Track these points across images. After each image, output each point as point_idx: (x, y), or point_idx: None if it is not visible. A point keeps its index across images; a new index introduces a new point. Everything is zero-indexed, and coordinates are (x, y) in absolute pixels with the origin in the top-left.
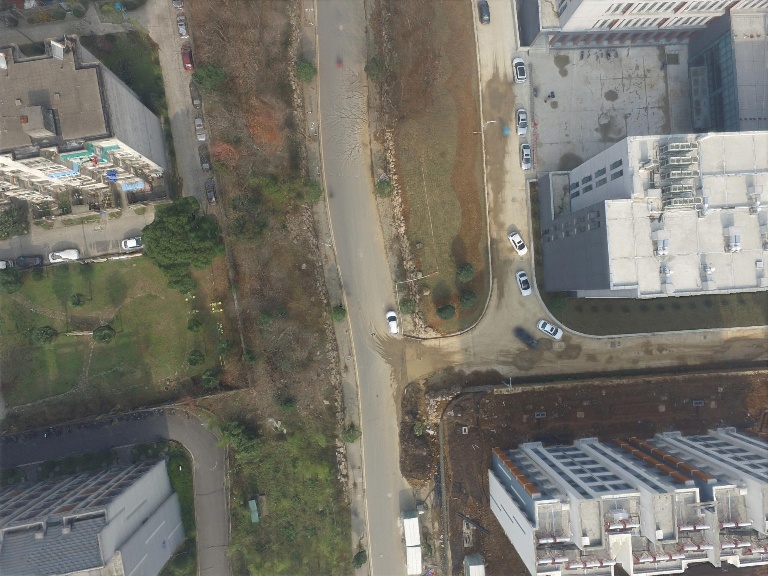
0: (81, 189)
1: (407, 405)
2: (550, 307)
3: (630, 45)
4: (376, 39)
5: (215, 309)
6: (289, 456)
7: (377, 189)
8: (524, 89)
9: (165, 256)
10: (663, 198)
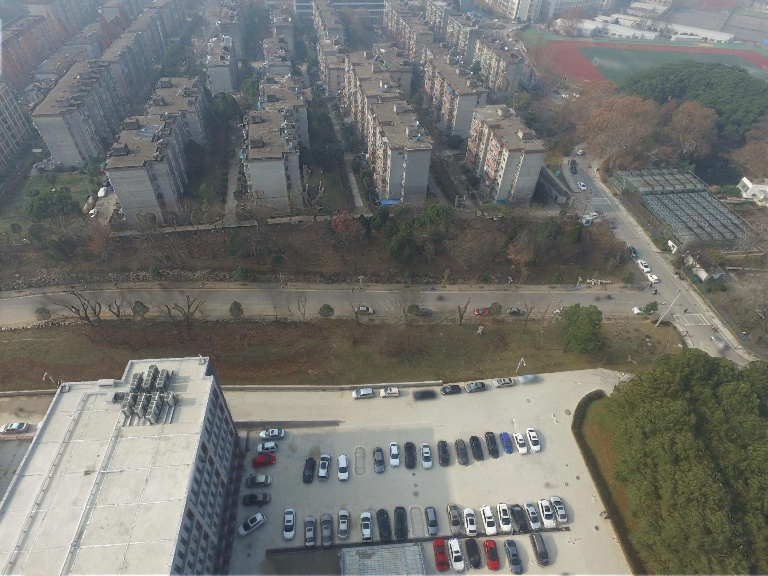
0: None
1: None
2: None
3: None
4: None
5: None
6: None
7: None
8: None
9: None
10: None
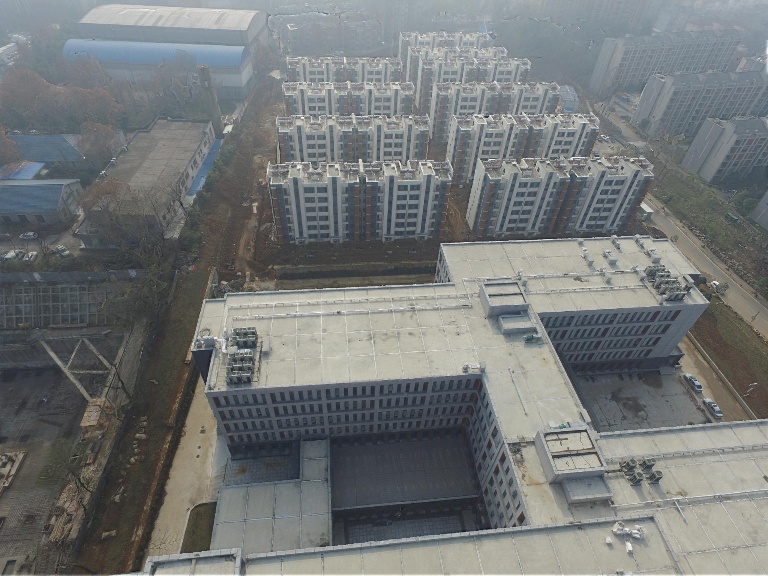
0: None
1: None
2: None
3: None
4: None
5: None
6: (729, 236)
7: None
8: None
9: None
10: None
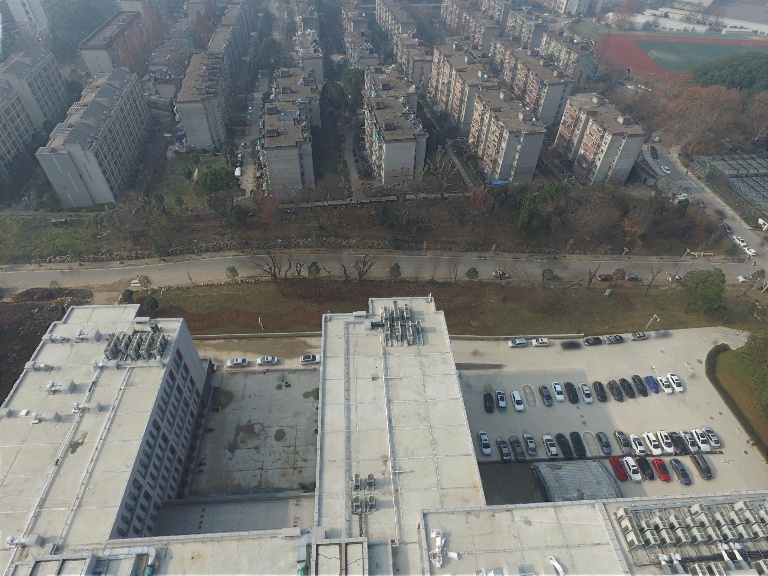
0: None
1: (77, 291)
2: None
3: None
4: None
5: None
6: (81, 237)
7: None
8: (296, 366)
9: None
10: None
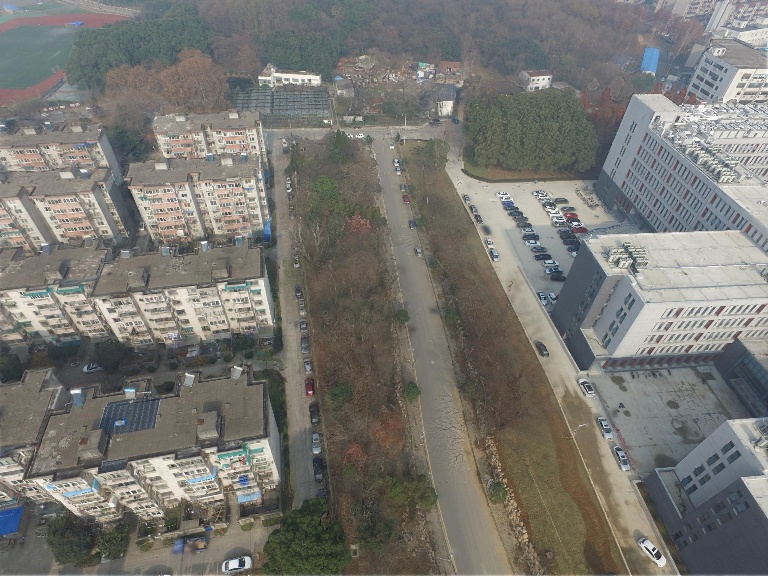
0: (192, 504)
1: None
2: None
3: (668, 367)
4: (462, 369)
5: None
6: None
7: (491, 492)
8: (595, 402)
9: (293, 564)
10: None
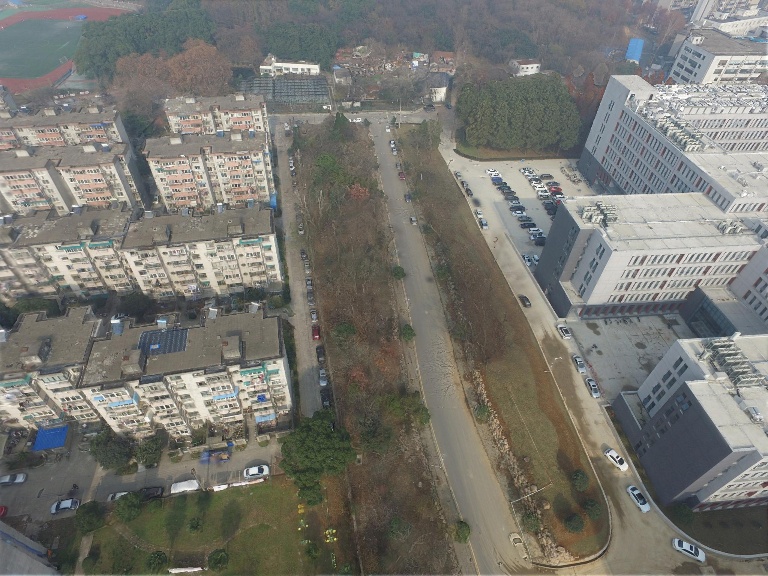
0: (215, 426)
1: None
2: (677, 520)
3: (638, 315)
4: (453, 318)
5: (330, 537)
6: None
7: (477, 412)
8: (572, 344)
9: (307, 456)
10: (731, 379)
